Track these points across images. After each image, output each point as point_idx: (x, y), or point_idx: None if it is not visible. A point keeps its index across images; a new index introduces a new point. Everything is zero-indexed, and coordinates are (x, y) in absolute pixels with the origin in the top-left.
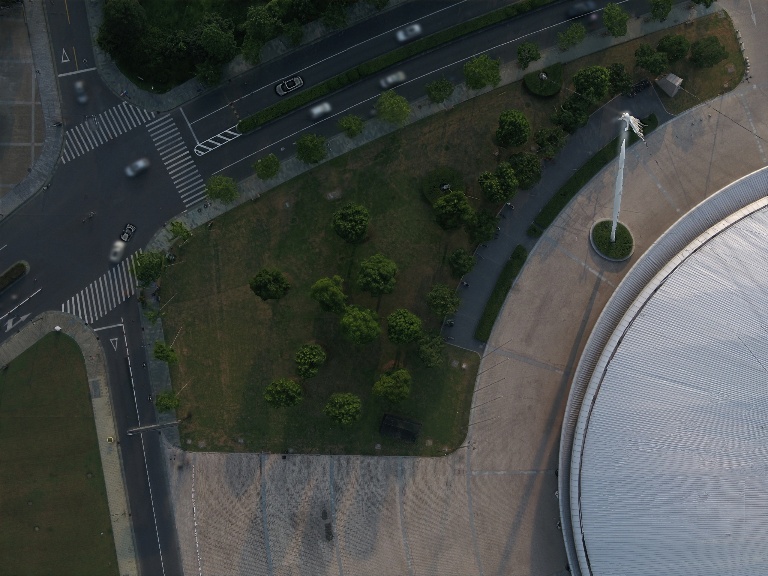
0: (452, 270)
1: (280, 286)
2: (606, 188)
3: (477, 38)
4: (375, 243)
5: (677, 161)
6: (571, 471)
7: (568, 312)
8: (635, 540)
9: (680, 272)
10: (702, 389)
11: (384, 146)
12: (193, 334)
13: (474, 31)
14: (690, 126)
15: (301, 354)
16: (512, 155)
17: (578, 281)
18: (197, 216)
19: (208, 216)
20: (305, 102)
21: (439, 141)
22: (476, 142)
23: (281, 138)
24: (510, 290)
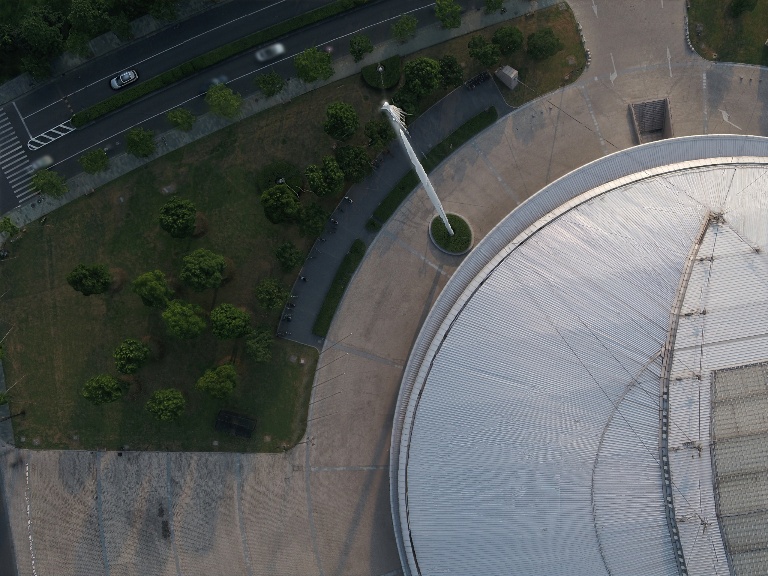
0: (281, 264)
1: (98, 281)
2: (446, 181)
3: (315, 31)
4: (210, 238)
5: (517, 154)
6: (399, 466)
7: (407, 306)
8: (457, 535)
9: (506, 265)
10: (520, 382)
11: (220, 140)
12: (26, 330)
13: (311, 24)
14: (531, 118)
15: (118, 349)
16: (340, 148)
17: (418, 275)
18: (30, 211)
19: (42, 211)
20: (139, 96)
21: (276, 135)
22: (313, 135)
23: (116, 132)
24: (349, 284)
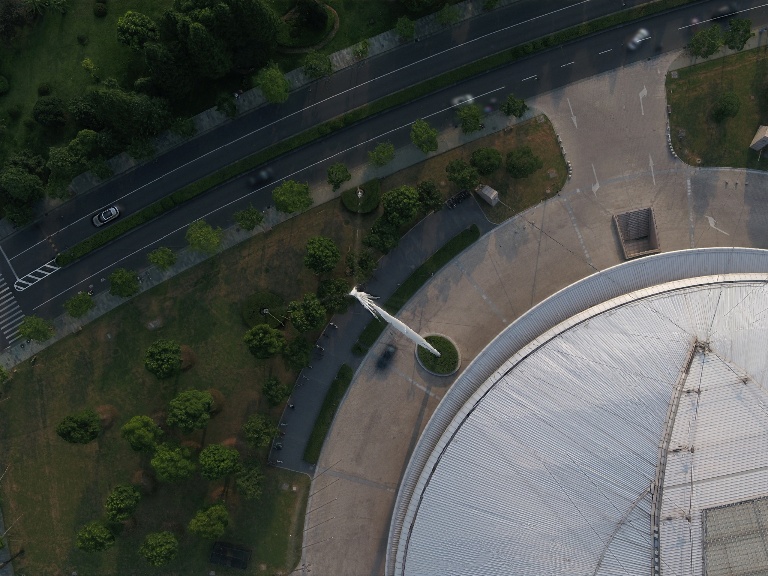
0: (268, 399)
1: (87, 431)
2: (430, 302)
3: (293, 157)
4: (198, 370)
5: (501, 271)
6: None
7: (397, 429)
8: None
9: (491, 396)
10: (510, 520)
11: (203, 272)
12: (22, 470)
13: (288, 151)
14: (513, 234)
15: (109, 499)
16: (321, 282)
17: (406, 397)
18: (20, 352)
19: (31, 351)
20: (121, 232)
21: (258, 264)
22: (296, 263)
23: (100, 269)
24: (338, 410)
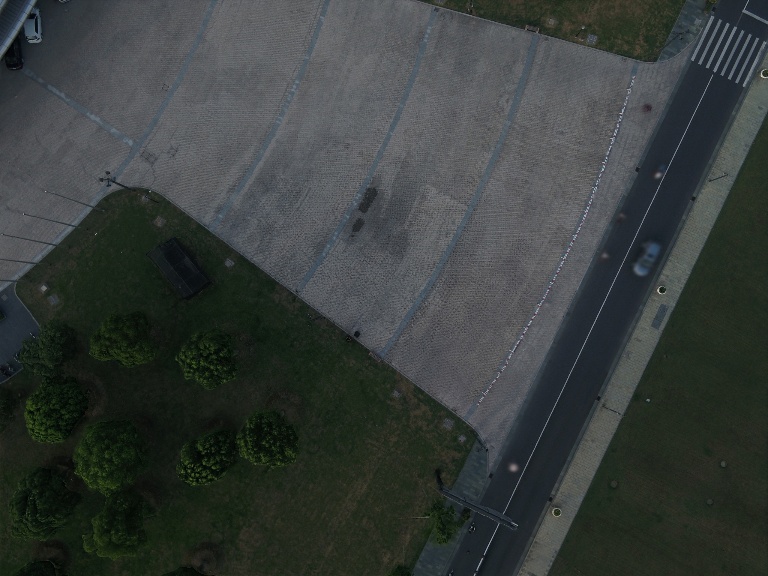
0: None
1: None
2: None
3: None
4: None
5: None
6: None
7: None
8: None
9: None
10: None
11: None
12: (361, 573)
13: None
14: None
15: None
16: None
17: None
18: None
19: None
20: None
21: None
22: None
23: None
24: None
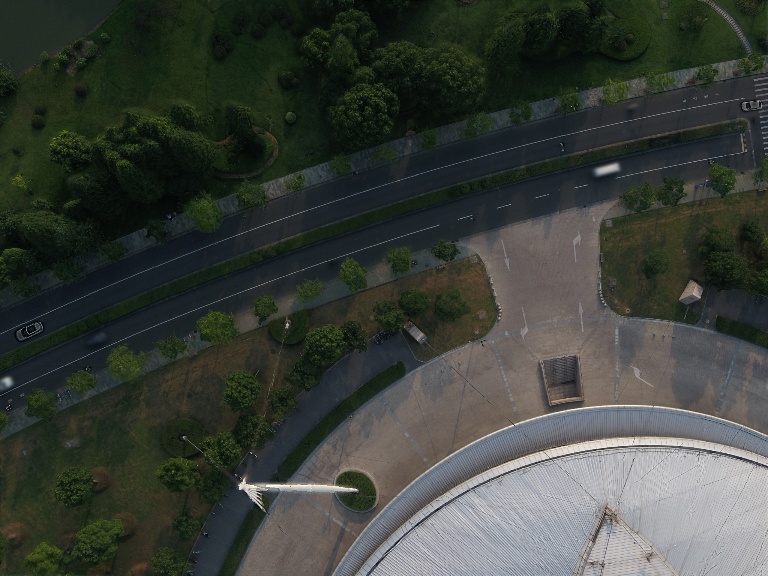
0: None
1: None
2: (352, 436)
3: (223, 283)
4: (113, 493)
5: (425, 409)
6: None
7: (311, 563)
8: None
9: (401, 547)
10: None
11: (125, 393)
12: None
13: (219, 277)
14: (439, 373)
15: None
16: (239, 418)
17: (322, 531)
18: None
19: None
20: (44, 349)
21: (181, 388)
22: (219, 389)
23: (20, 384)
24: (252, 540)
